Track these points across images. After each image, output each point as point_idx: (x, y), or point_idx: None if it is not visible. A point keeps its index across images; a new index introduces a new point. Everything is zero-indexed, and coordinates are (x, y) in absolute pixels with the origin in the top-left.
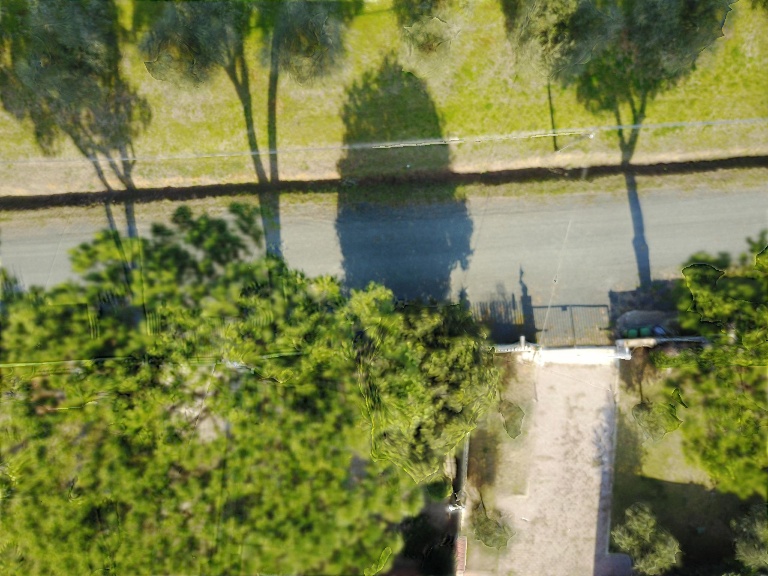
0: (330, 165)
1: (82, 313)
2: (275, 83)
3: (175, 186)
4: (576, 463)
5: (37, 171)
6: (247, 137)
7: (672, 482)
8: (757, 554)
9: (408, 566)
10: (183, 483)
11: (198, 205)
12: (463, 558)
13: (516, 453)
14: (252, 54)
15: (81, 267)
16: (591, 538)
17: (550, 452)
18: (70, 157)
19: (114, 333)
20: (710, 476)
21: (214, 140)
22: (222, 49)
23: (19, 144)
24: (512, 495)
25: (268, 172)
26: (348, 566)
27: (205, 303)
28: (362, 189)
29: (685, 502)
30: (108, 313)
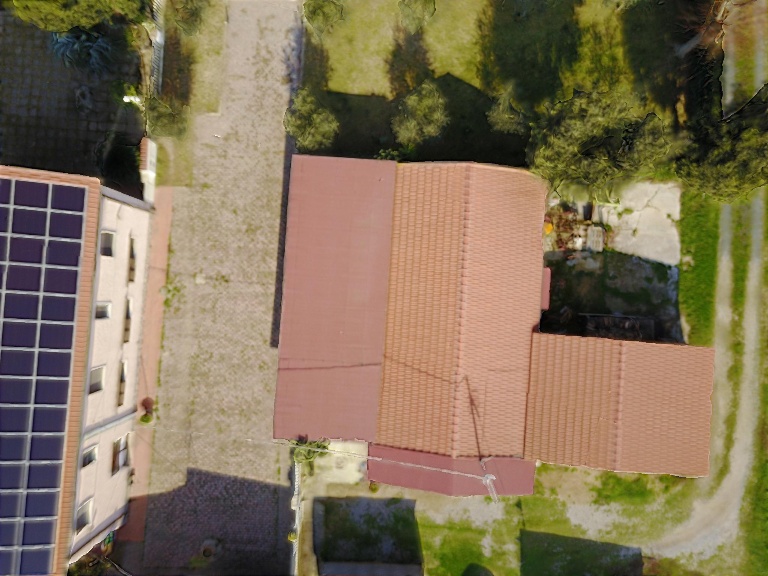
0: None
1: None
2: None
3: None
4: (266, 81)
5: None
6: None
7: (355, 94)
8: (405, 122)
9: (105, 184)
10: None
11: None
12: (145, 157)
13: (208, 73)
14: None
15: None
16: (280, 151)
17: (241, 72)
18: None
19: None
20: (390, 88)
21: None
22: None
23: None
24: (205, 113)
25: None
26: None
27: None
28: None
29: (367, 113)
30: None
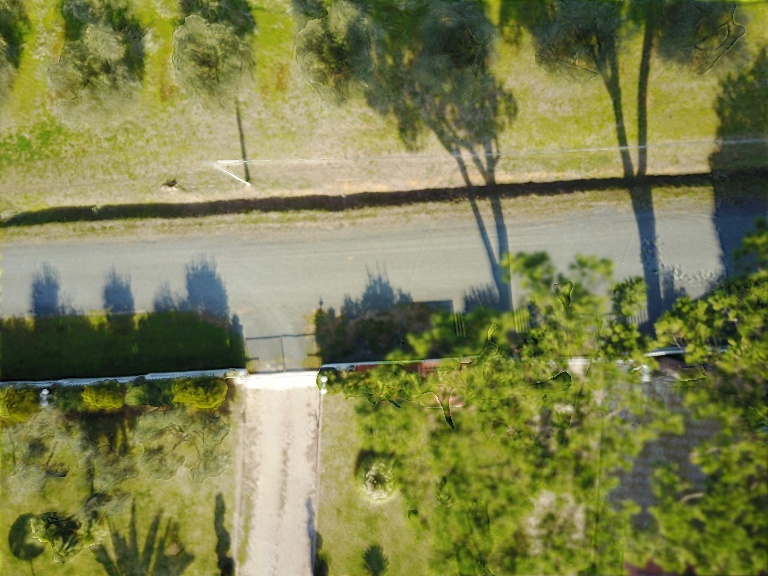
0: (703, 159)
1: (447, 310)
2: (646, 76)
3: (536, 181)
4: None
5: (398, 167)
6: (616, 131)
7: None
8: None
9: None
10: (557, 486)
11: (566, 200)
12: None
13: None
14: (623, 47)
15: (447, 263)
16: None
17: None
18: (433, 153)
19: (481, 330)
20: None
21: (581, 134)
22: (594, 43)
23: (381, 140)
24: None
25: (636, 166)
26: (740, 575)
27: (577, 300)
28: (738, 183)
29: None
30: (474, 310)
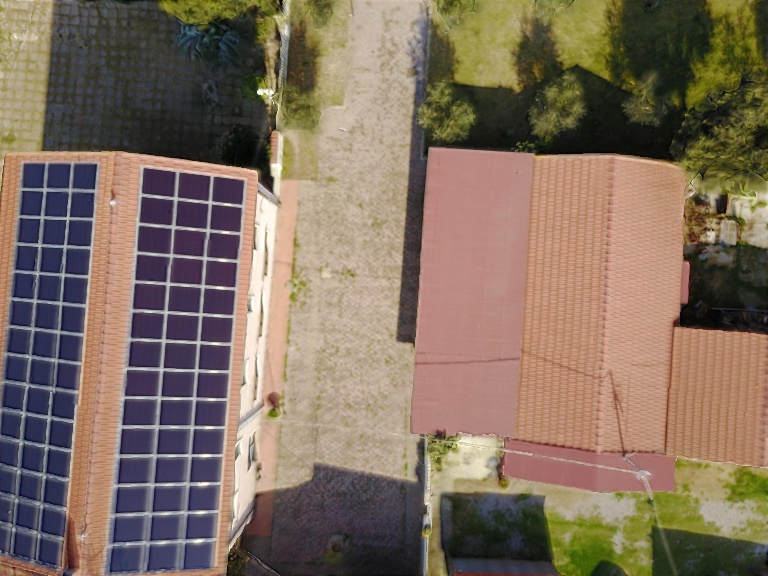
0: None
1: None
2: None
3: None
4: (391, 74)
5: None
6: None
7: (482, 87)
8: (545, 114)
9: None
10: (8, 106)
11: None
12: (275, 150)
13: (333, 66)
14: None
15: None
16: (406, 145)
17: (366, 65)
18: None
19: None
20: (518, 80)
21: None
22: None
23: None
24: (330, 107)
25: None
26: None
27: None
28: None
29: (494, 106)
30: None
